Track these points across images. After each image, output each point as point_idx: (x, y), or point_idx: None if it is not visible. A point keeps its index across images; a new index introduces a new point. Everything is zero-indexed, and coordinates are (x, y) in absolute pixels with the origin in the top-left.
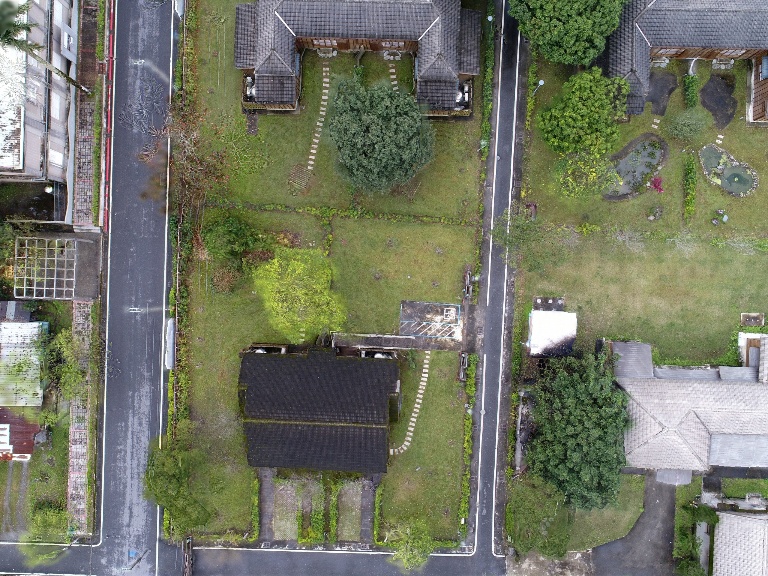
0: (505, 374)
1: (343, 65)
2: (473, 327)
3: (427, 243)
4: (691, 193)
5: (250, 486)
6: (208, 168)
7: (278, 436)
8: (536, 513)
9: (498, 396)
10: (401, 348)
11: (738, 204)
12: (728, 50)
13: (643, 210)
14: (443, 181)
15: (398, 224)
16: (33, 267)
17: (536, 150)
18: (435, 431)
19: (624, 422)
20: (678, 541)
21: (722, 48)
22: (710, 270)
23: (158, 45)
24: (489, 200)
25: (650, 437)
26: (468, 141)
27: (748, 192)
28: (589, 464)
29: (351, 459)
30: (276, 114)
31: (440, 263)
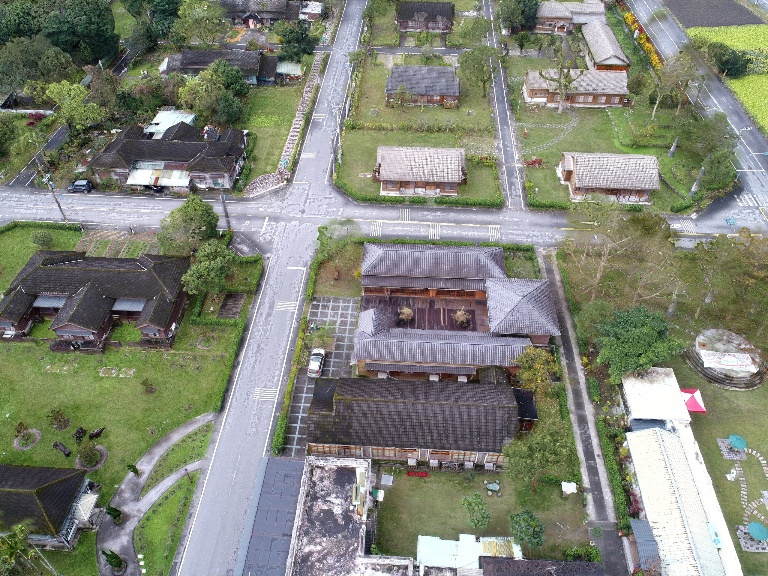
0: (494, 20)
1: None
2: None
3: None
4: None
5: None
6: None
7: (411, 7)
8: None
9: (492, 23)
10: None
11: None
12: None
13: None
14: None
15: None
16: None
17: None
18: None
19: None
20: None
21: None
22: None
23: None
24: None
25: (546, 4)
26: None
27: None
28: None
29: None
30: None
31: (466, 4)
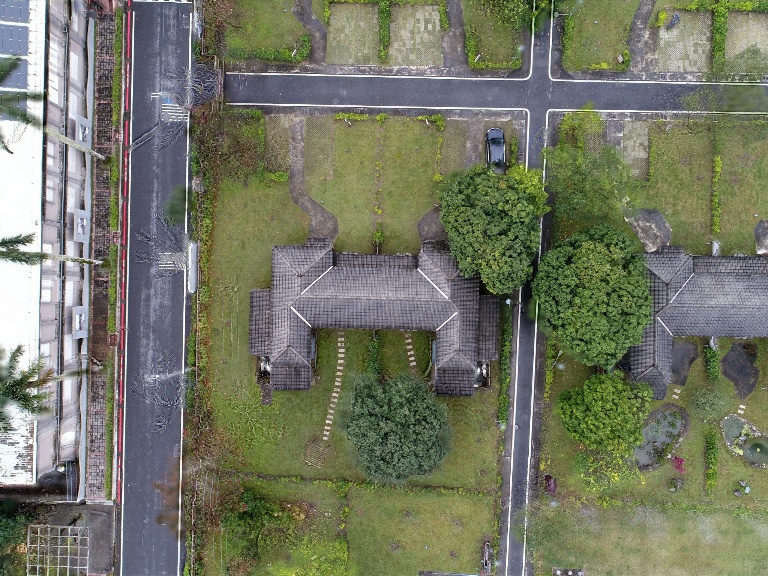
0: None
1: (358, 335)
2: None
3: (445, 513)
4: (713, 467)
5: None
6: (222, 443)
7: None
8: None
9: None
10: None
11: (760, 475)
12: None
13: (664, 481)
14: (460, 451)
15: (415, 494)
16: (46, 555)
17: (555, 420)
18: None
19: None
20: None
21: None
22: (732, 541)
23: (170, 315)
24: (507, 470)
25: None
26: (486, 411)
27: None
28: None
29: None
30: None
31: (458, 534)
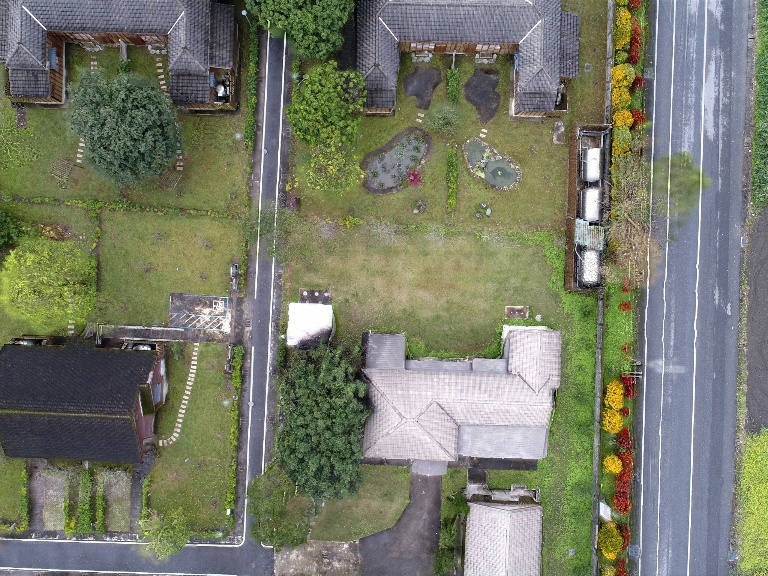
0: (273, 366)
1: (111, 59)
2: (241, 319)
3: (195, 236)
4: (452, 187)
5: (20, 477)
6: None
7: (27, 426)
8: (264, 502)
9: (266, 388)
10: (167, 340)
11: (502, 198)
12: (483, 45)
13: (408, 203)
14: (211, 174)
15: (166, 217)
16: None
17: (302, 144)
18: (203, 422)
19: (365, 413)
20: (444, 532)
21: (472, 42)
22: (475, 263)
23: None
24: (256, 193)
25: (391, 428)
26: (235, 135)
27: (511, 186)
28: (321, 454)
29: (104, 449)
30: (45, 108)
31: (208, 256)
